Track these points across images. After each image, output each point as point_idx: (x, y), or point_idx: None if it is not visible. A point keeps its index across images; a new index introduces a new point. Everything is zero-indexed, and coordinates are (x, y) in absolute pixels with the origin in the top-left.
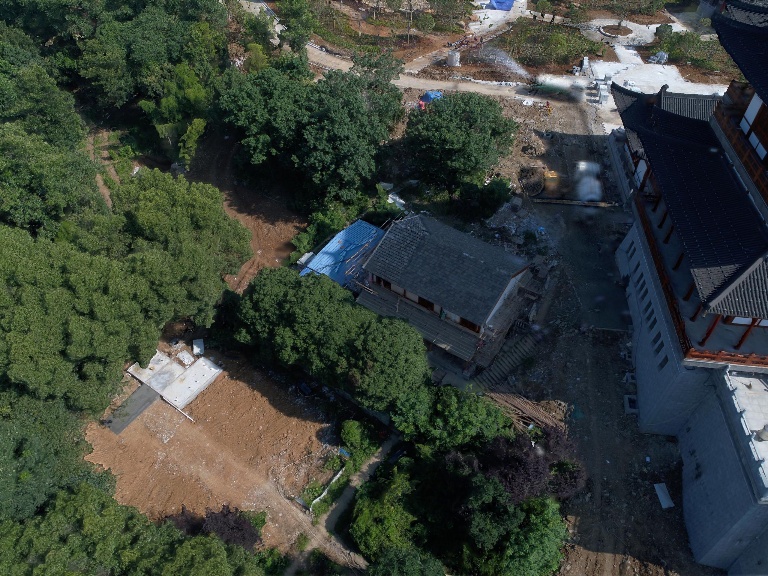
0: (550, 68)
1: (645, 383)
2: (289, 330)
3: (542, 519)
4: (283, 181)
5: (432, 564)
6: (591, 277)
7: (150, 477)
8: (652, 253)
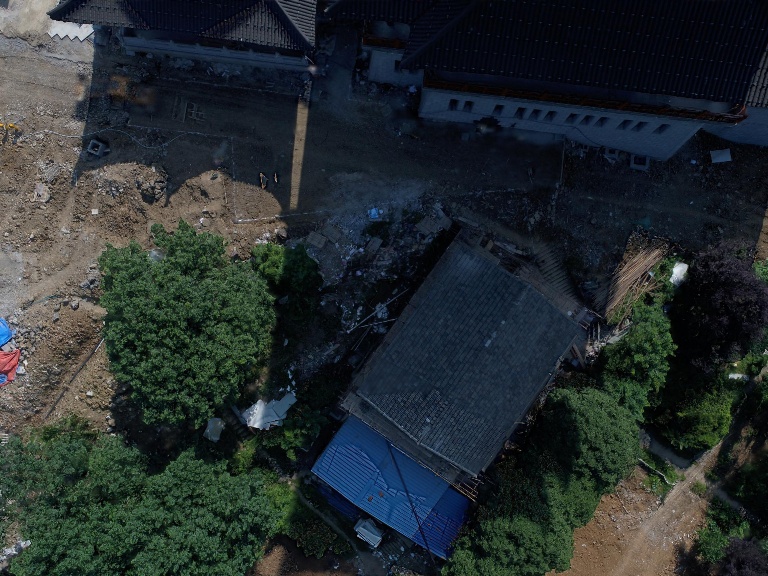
0: None
1: None
2: None
3: None
4: None
5: None
6: (470, 164)
7: None
8: (554, 102)
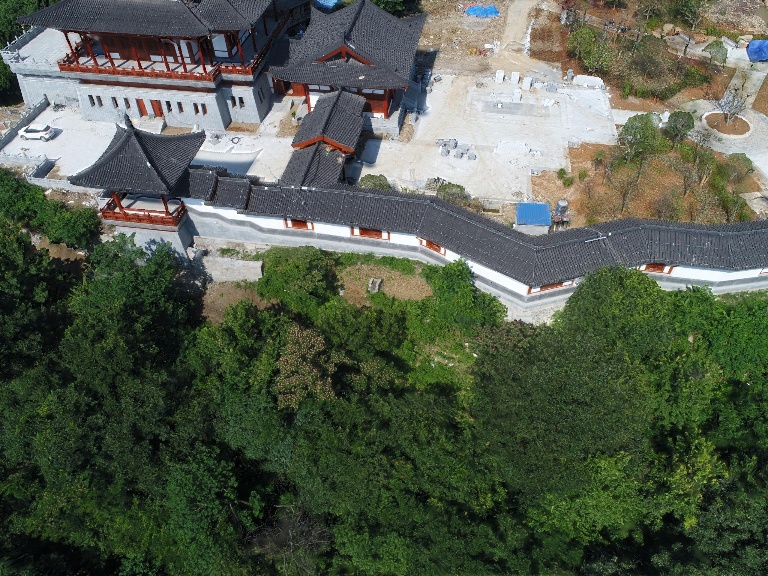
0: (569, 62)
1: None
2: None
3: None
4: None
5: None
6: None
7: None
8: None
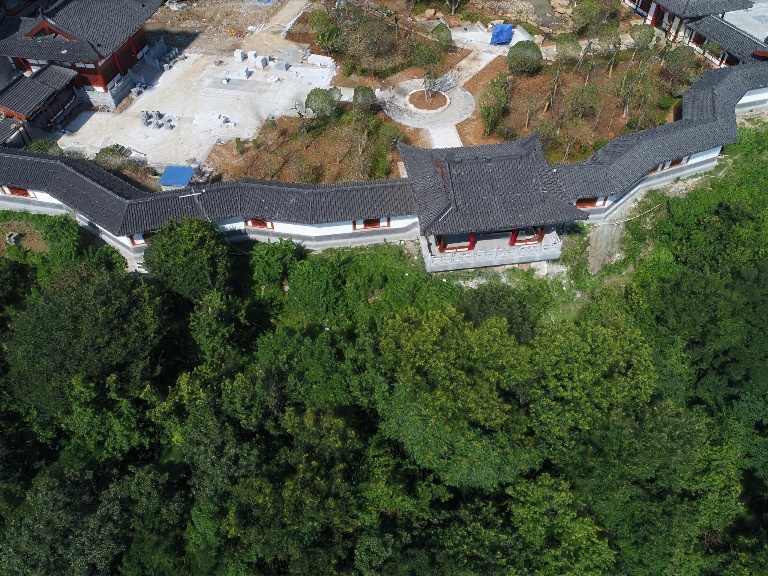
0: None
1: None
2: None
3: None
4: None
5: None
6: None
7: None
8: None
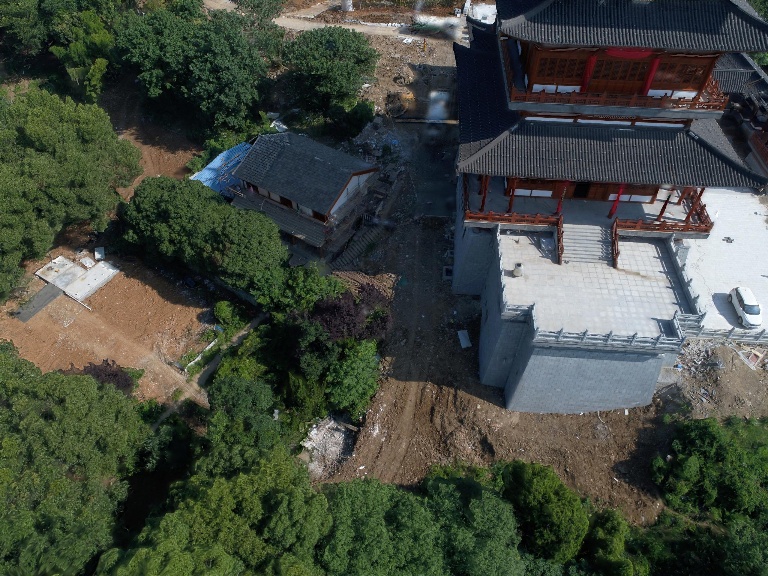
0: (434, 11)
1: (456, 254)
2: (165, 225)
3: (354, 352)
4: (184, 116)
5: (260, 384)
6: (430, 178)
7: (51, 353)
8: None
